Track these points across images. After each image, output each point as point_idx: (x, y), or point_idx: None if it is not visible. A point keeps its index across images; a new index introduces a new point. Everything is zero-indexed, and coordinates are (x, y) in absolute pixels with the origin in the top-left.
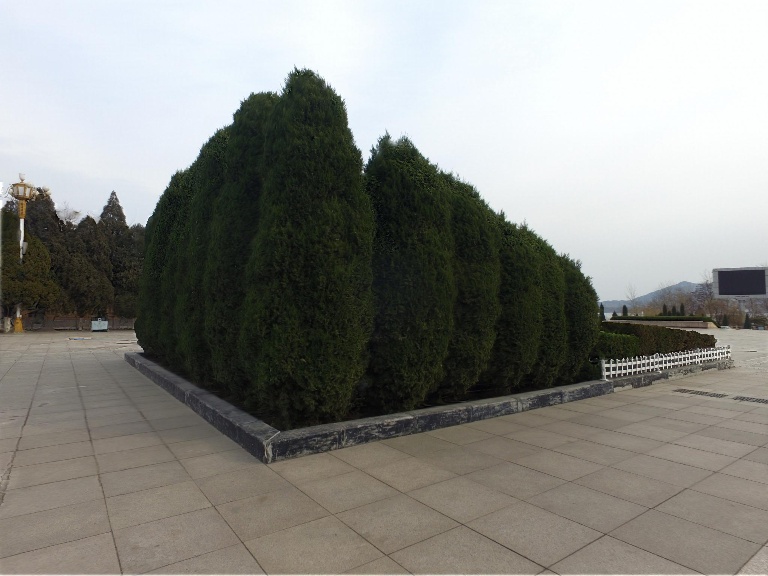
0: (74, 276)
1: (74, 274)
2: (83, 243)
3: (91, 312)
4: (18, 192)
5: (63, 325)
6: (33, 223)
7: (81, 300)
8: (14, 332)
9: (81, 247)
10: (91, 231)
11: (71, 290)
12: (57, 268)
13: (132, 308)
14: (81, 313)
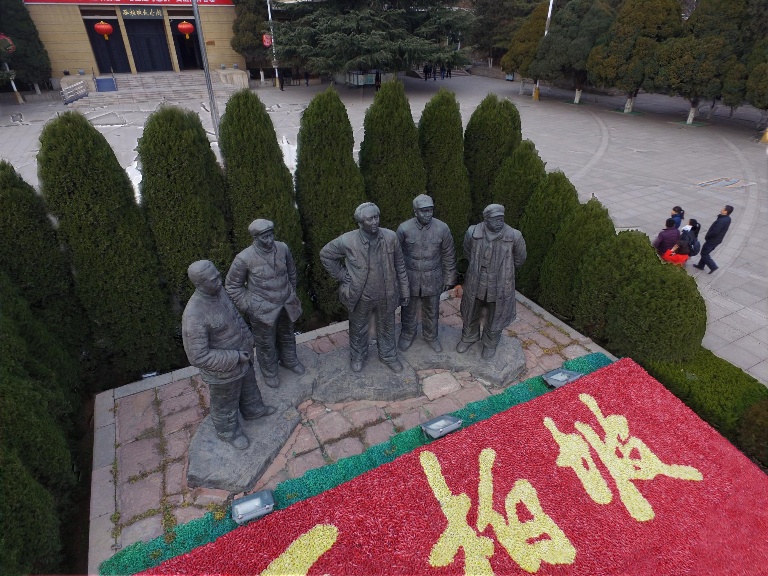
0: None
1: None
2: None
3: None
4: None
5: None
6: None
7: None
8: (759, 142)
9: None
10: None
11: None
12: None
13: None
14: None
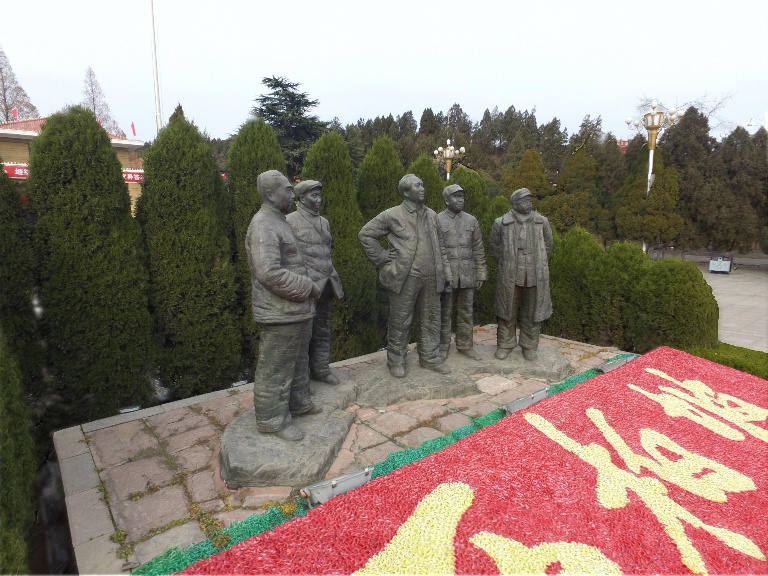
0: (702, 206)
1: (702, 204)
2: (723, 164)
3: (729, 247)
4: (647, 123)
5: (740, 256)
6: (675, 150)
7: (712, 234)
8: None
9: (720, 169)
10: (737, 147)
11: (700, 222)
12: (688, 198)
13: None
14: (716, 248)
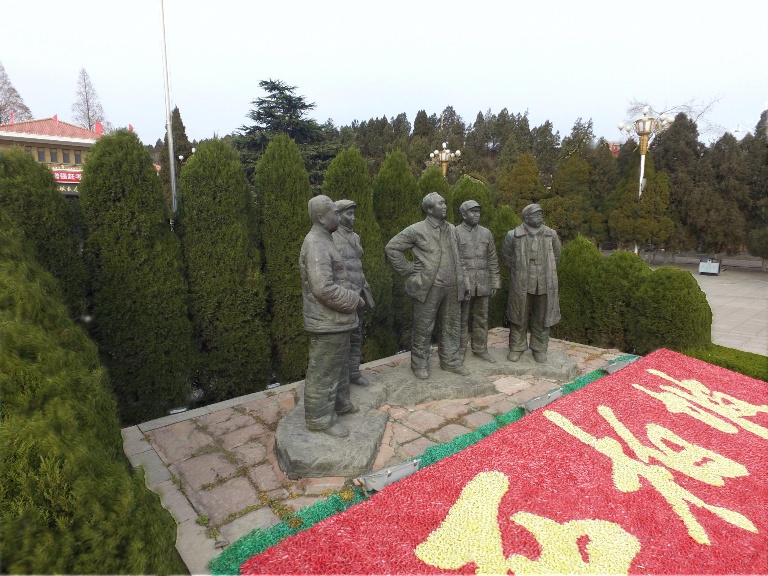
0: (692, 210)
1: (692, 207)
2: (712, 169)
3: (718, 249)
4: (639, 128)
5: None
6: (665, 155)
7: (701, 236)
8: None
9: (709, 174)
10: (725, 152)
11: (690, 225)
12: (678, 201)
13: (767, 247)
14: (705, 250)
